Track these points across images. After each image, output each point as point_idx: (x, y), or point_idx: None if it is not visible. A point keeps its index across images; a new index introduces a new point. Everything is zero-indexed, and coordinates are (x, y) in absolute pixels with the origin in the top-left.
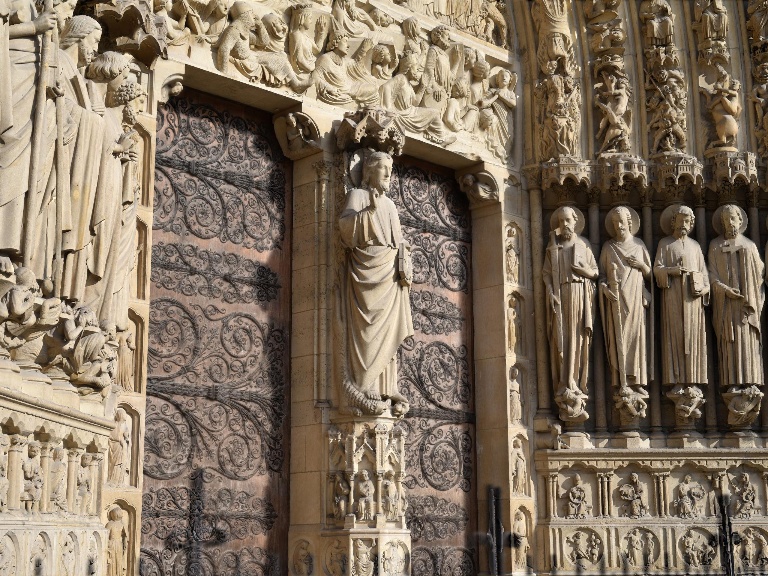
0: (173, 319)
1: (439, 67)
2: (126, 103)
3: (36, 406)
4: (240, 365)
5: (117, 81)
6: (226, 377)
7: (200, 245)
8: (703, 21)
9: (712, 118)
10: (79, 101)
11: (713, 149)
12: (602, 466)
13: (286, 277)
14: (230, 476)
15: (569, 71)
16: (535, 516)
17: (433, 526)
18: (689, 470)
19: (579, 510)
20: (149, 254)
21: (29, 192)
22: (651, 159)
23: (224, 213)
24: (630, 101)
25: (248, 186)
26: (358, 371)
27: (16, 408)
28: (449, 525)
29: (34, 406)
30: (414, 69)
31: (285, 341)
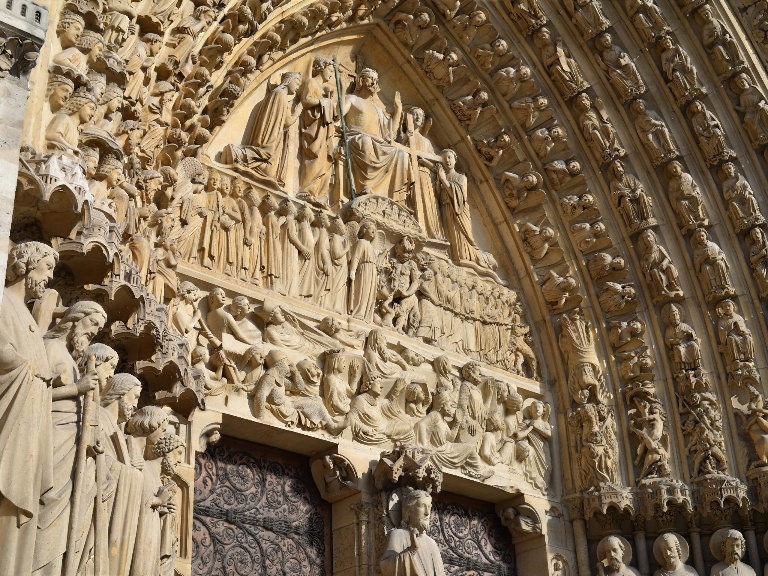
0: None
1: (472, 402)
2: (164, 455)
3: None
4: None
5: (156, 434)
6: None
7: None
8: (729, 344)
9: (750, 438)
10: (118, 457)
11: (755, 470)
12: None
13: None
14: None
15: (601, 399)
16: None
17: None
18: None
19: None
20: None
21: (67, 553)
22: (693, 483)
23: (263, 561)
24: (665, 425)
25: (287, 531)
26: None
27: None
28: None
29: None
30: (447, 405)
31: None
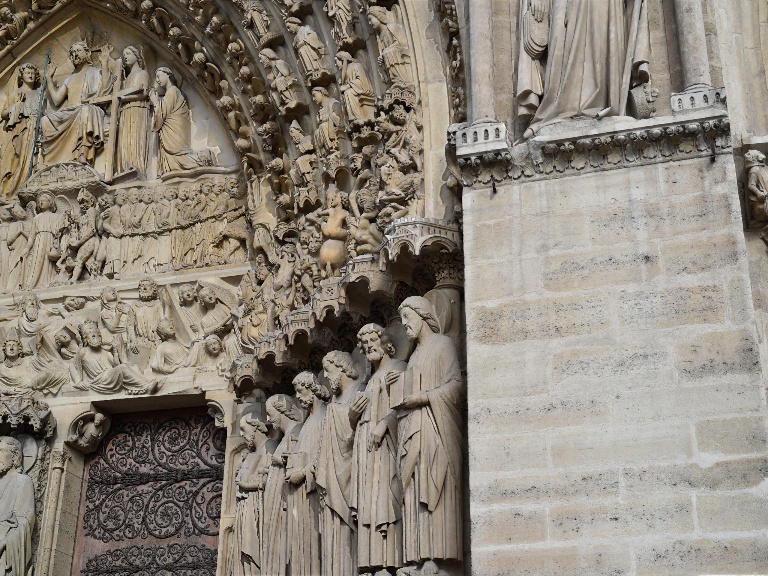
0: None
1: None
2: None
3: None
4: None
5: None
6: None
7: None
8: None
9: None
10: None
11: None
12: None
13: None
14: None
15: (272, 258)
16: None
17: None
18: None
19: None
20: None
21: None
22: None
23: None
24: None
25: None
26: None
27: None
28: None
29: None
30: (90, 338)
31: None
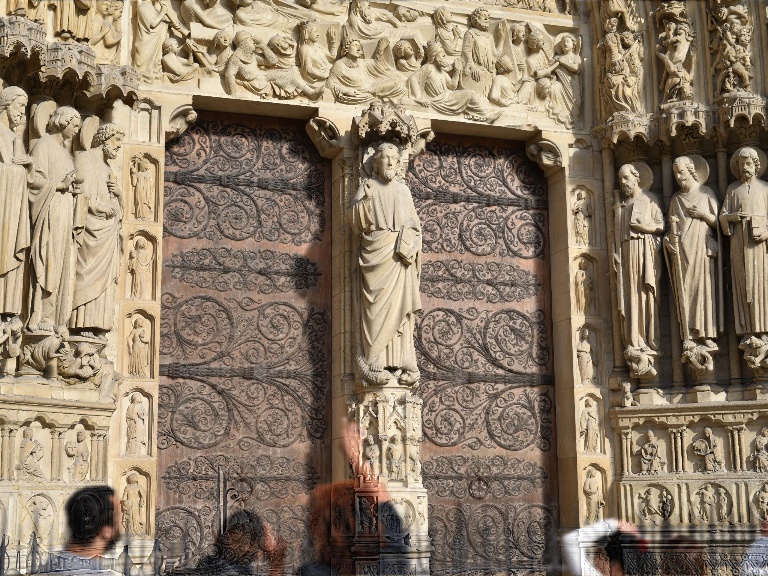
0: (208, 313)
1: (476, 48)
2: (104, 143)
3: None
4: (278, 347)
5: (68, 130)
6: (263, 358)
7: (234, 246)
8: None
9: None
10: None
11: None
12: (672, 422)
13: (327, 265)
14: (268, 444)
15: (630, 25)
16: (611, 473)
17: (502, 484)
18: (767, 422)
19: (651, 466)
20: (159, 262)
21: None
22: (715, 103)
23: (258, 216)
24: (694, 45)
25: (283, 189)
26: (366, 346)
27: None
28: (523, 483)
29: None
30: (440, 57)
31: (327, 322)
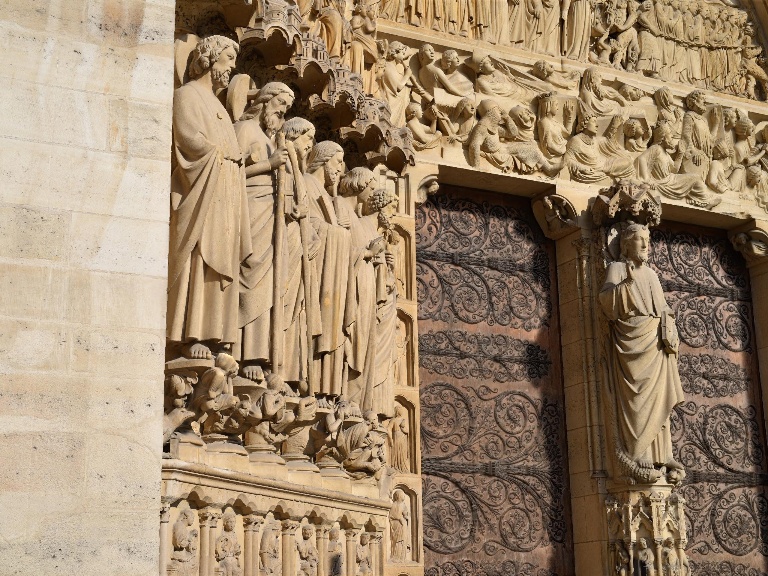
0: (447, 402)
1: (696, 132)
2: (380, 210)
3: (303, 493)
4: (516, 441)
5: (365, 193)
6: (502, 453)
7: (468, 330)
8: None
9: None
10: (326, 218)
11: None
12: None
13: (556, 353)
14: (513, 548)
15: None
16: None
17: None
18: None
19: None
20: (416, 344)
21: (274, 308)
22: None
23: (490, 298)
24: None
25: (512, 270)
26: (629, 440)
27: (283, 496)
28: None
29: (301, 494)
30: (668, 138)
31: (559, 415)
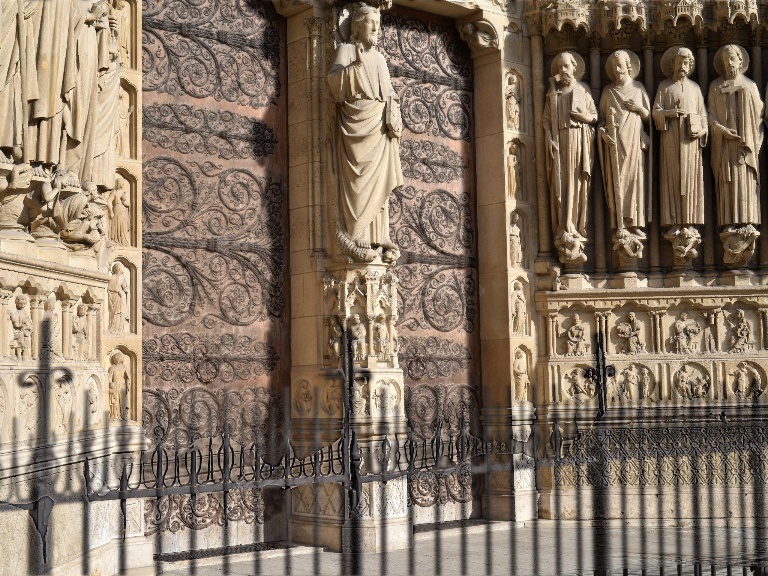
0: (170, 176)
1: None
2: None
3: (17, 263)
4: (239, 218)
5: None
6: (225, 230)
7: (195, 104)
8: None
9: None
10: None
11: None
12: (600, 306)
13: (283, 132)
14: (232, 322)
15: None
16: (536, 354)
17: (436, 365)
18: (685, 308)
19: (577, 348)
20: (139, 116)
21: None
22: (651, 1)
23: (218, 72)
24: None
25: (241, 45)
26: (349, 221)
27: None
28: (452, 364)
29: (15, 263)
30: None
31: (283, 194)
